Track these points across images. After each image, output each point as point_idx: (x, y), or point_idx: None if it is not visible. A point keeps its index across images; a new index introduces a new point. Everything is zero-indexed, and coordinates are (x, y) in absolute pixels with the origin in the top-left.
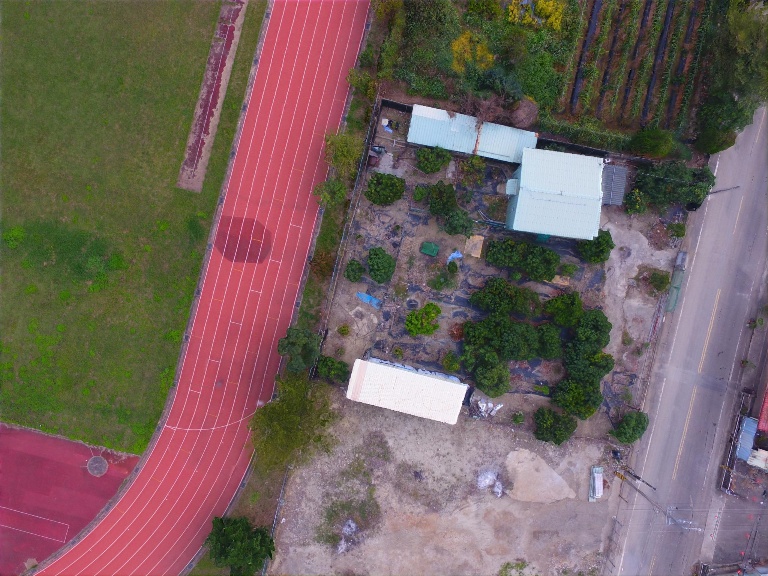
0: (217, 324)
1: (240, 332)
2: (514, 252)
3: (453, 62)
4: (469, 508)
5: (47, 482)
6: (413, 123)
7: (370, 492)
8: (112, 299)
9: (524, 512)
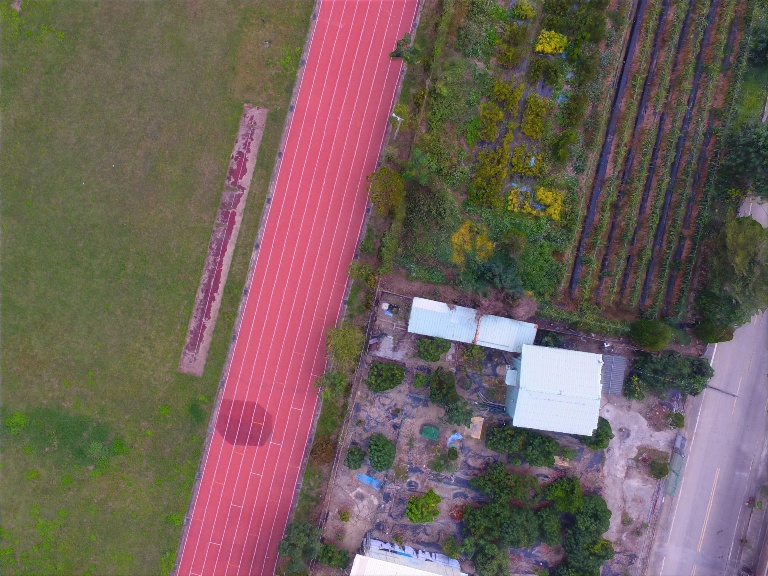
0: (218, 507)
1: (241, 515)
2: (514, 442)
3: (453, 254)
4: None
5: None
6: (413, 314)
7: None
8: (113, 484)
9: None
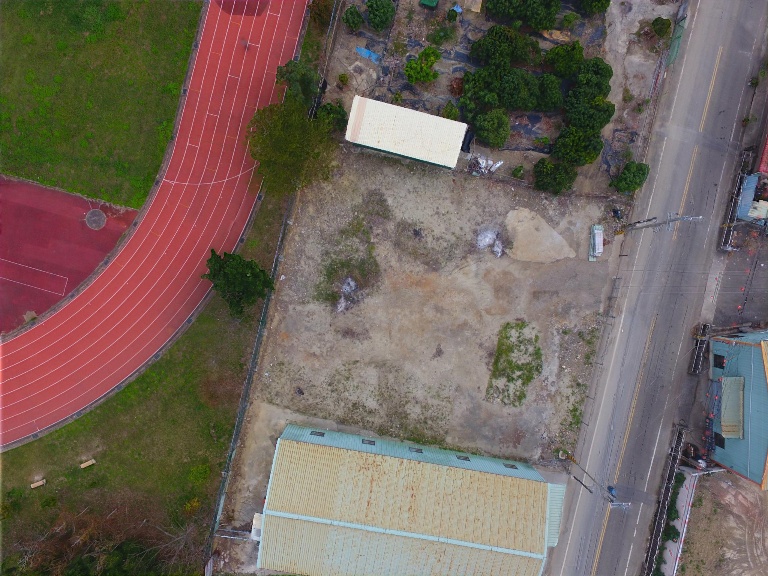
0: (215, 77)
1: (238, 86)
2: None
3: None
4: (469, 268)
5: (45, 234)
6: None
7: (369, 250)
8: (109, 50)
9: (524, 272)
